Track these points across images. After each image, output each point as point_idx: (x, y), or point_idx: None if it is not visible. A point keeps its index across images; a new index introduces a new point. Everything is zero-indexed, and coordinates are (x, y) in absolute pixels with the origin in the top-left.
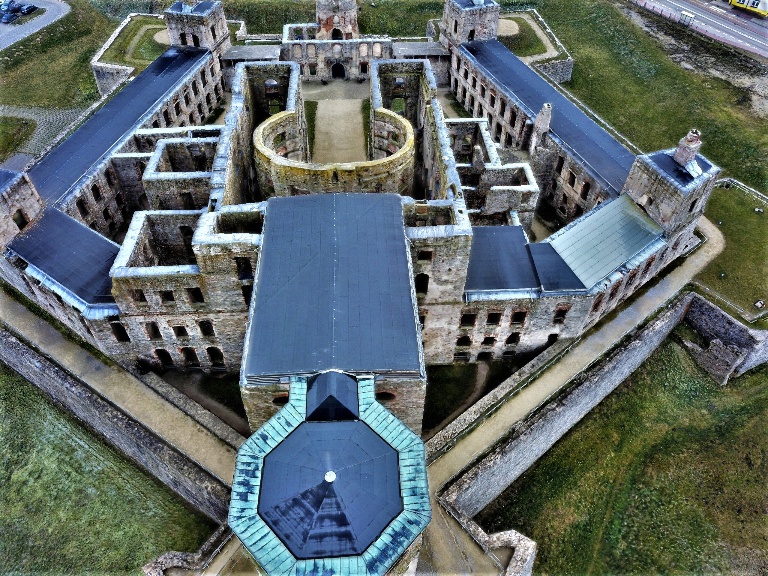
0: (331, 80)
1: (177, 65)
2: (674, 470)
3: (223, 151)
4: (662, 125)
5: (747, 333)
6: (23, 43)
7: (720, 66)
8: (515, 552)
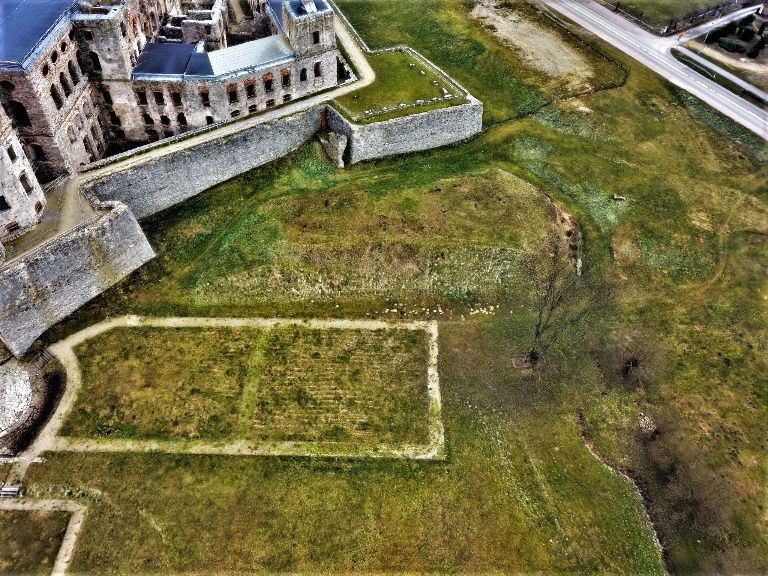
0: None
1: None
2: (274, 205)
3: None
4: (400, 22)
5: (348, 126)
6: None
7: None
8: (112, 209)
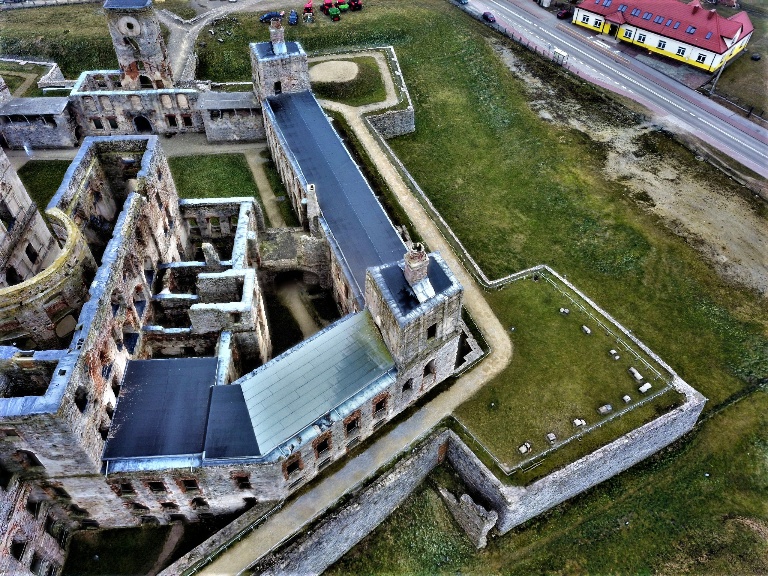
0: None
1: None
2: None
3: None
4: (502, 188)
5: (498, 491)
6: None
7: (583, 115)
8: None
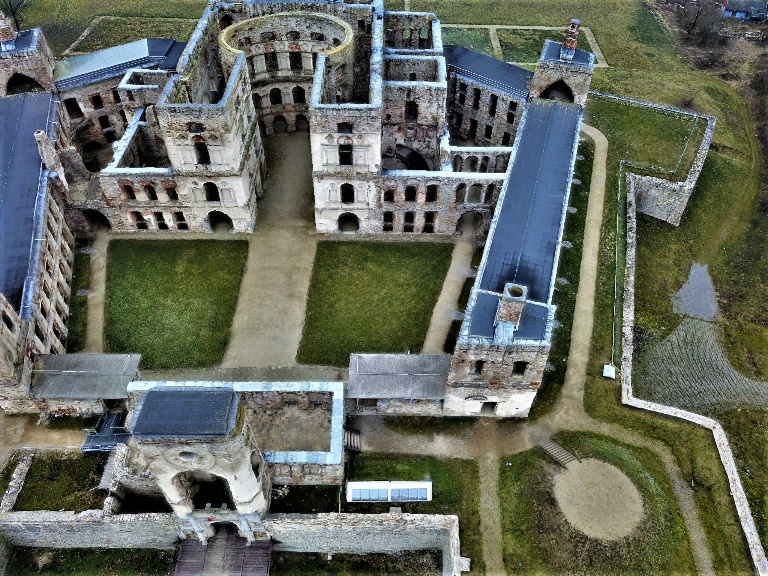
0: None
1: (505, 279)
2: None
3: (376, 29)
4: None
5: None
6: None
7: None
8: None
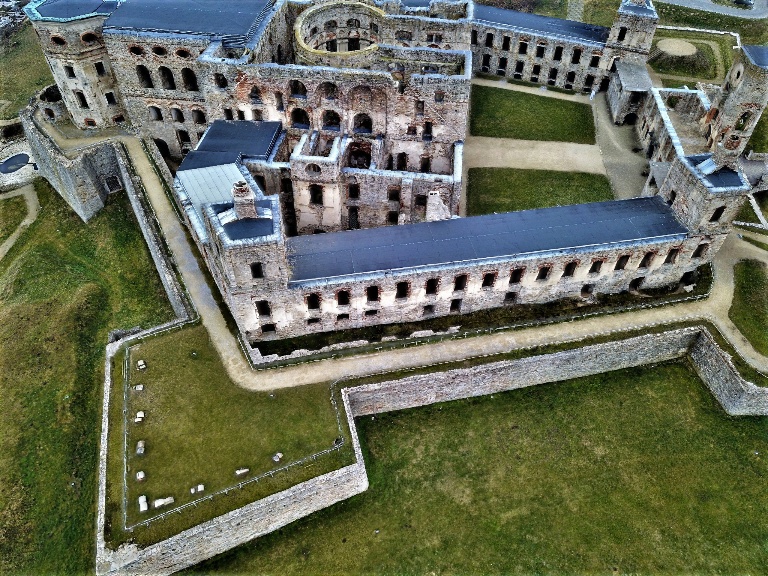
0: (645, 155)
1: (570, 30)
2: None
3: None
4: (583, 506)
5: None
6: (680, 8)
7: None
8: None
